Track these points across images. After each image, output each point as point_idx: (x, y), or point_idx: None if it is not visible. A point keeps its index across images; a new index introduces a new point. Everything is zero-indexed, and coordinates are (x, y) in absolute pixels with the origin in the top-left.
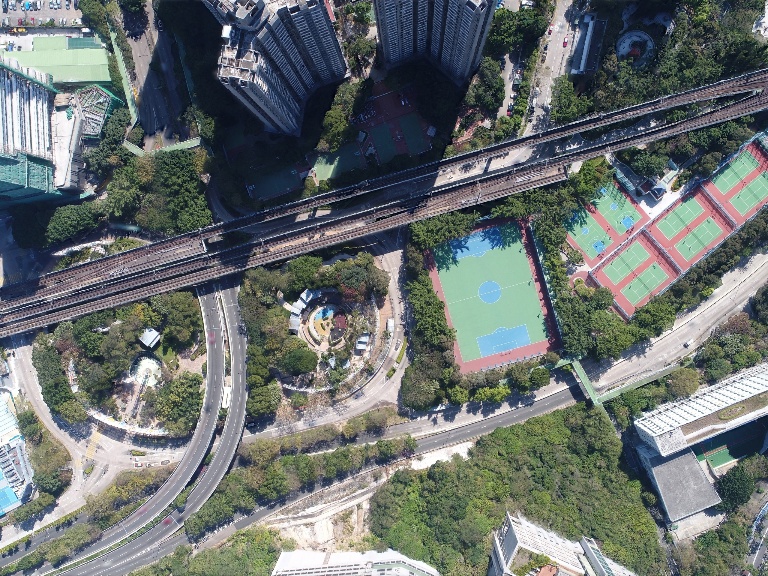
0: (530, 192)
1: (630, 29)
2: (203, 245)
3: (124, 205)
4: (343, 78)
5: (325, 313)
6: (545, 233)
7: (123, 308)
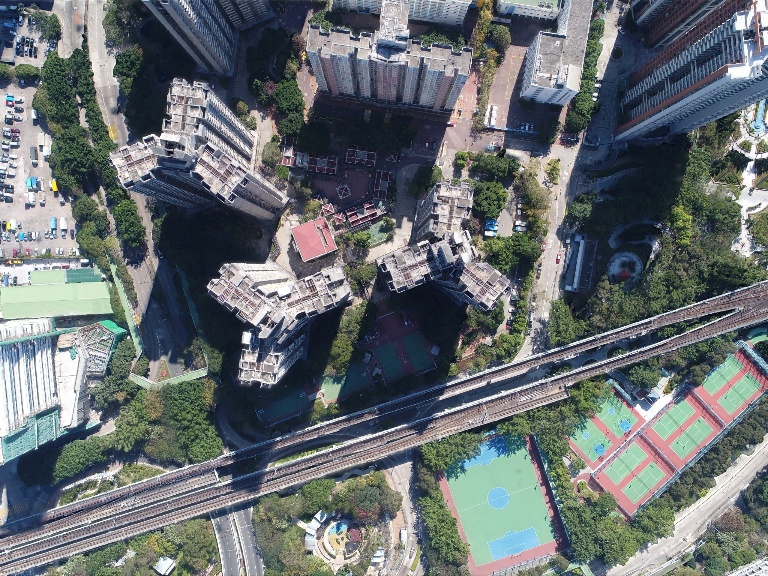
0: (534, 412)
1: (619, 250)
2: (215, 474)
3: (133, 441)
4: (346, 301)
5: (339, 528)
6: (549, 447)
7: (136, 538)
